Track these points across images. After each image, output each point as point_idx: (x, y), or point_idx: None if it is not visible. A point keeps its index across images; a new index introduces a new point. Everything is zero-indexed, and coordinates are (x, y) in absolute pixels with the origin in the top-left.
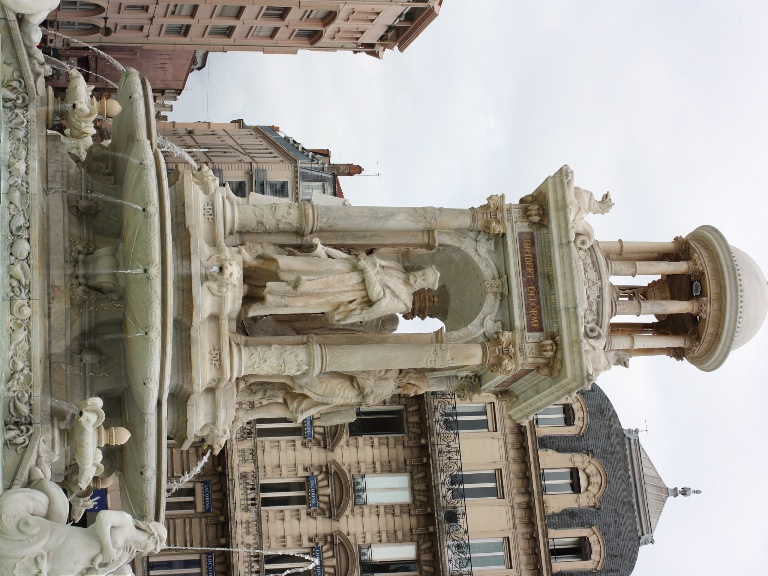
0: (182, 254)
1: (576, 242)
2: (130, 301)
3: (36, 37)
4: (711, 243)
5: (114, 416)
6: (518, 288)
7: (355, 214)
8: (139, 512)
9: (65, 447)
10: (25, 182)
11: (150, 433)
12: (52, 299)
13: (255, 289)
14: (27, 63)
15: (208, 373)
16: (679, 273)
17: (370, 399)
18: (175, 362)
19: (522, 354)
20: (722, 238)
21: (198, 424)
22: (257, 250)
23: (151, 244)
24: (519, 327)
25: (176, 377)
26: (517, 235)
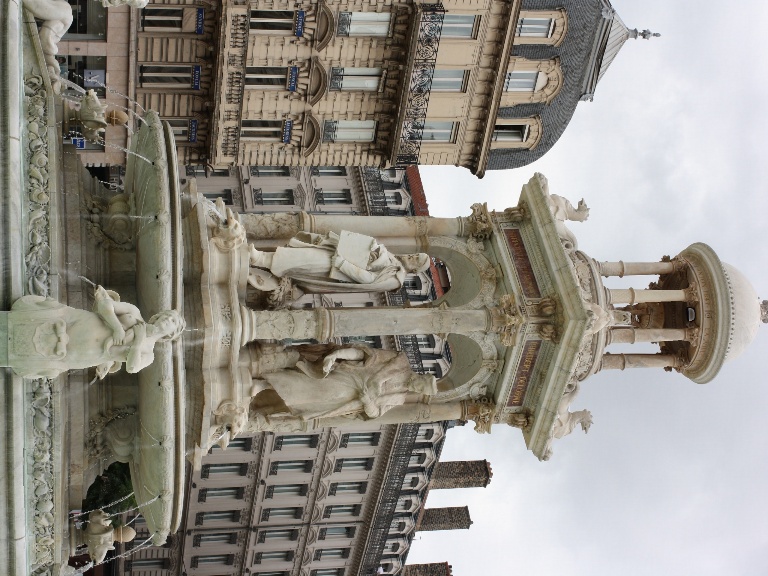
0: (195, 408)
1: None
2: None
3: None
4: (718, 315)
5: None
6: (510, 378)
7: (371, 331)
8: None
9: None
10: (49, 464)
11: None
12: (72, 472)
13: None
14: None
15: (209, 446)
16: None
17: None
18: None
19: (496, 420)
20: (728, 321)
21: None
22: (269, 361)
23: (164, 520)
24: (500, 402)
25: None
26: (525, 343)
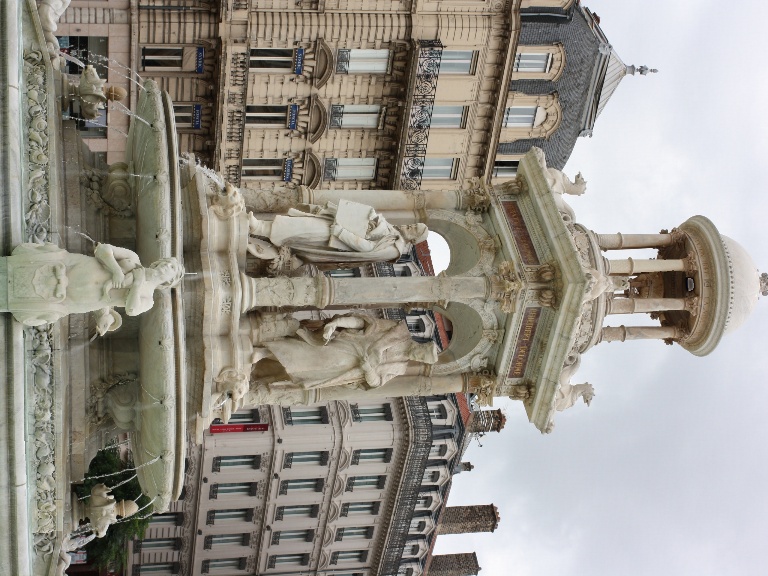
0: (196, 374)
1: None
2: None
3: None
4: (717, 284)
5: None
6: (511, 348)
7: (371, 298)
8: None
9: None
10: (50, 424)
11: None
12: (73, 440)
13: None
14: None
15: (211, 419)
16: None
17: None
18: None
19: (498, 392)
20: (728, 288)
21: None
22: (270, 329)
23: (165, 482)
24: (502, 374)
25: None
26: (525, 310)
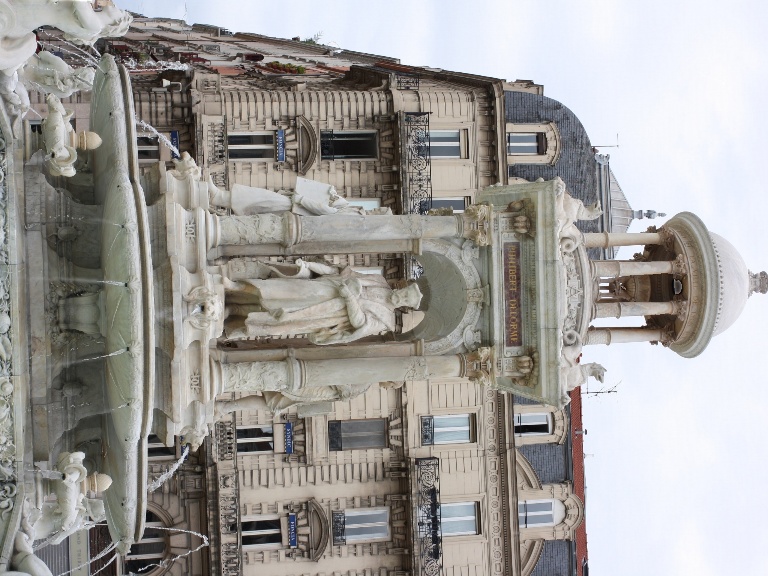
0: (164, 289)
1: (561, 246)
2: (112, 360)
3: (12, 86)
4: (697, 241)
5: (95, 426)
6: (500, 301)
7: (340, 227)
8: (120, 531)
9: None
10: (4, 251)
11: (131, 469)
12: (33, 351)
13: (236, 309)
14: (3, 112)
15: (188, 398)
16: None
17: (347, 398)
18: (156, 388)
19: (499, 369)
20: (708, 238)
21: (177, 430)
22: (239, 268)
23: (133, 322)
24: (498, 341)
25: (156, 403)
26: (502, 246)
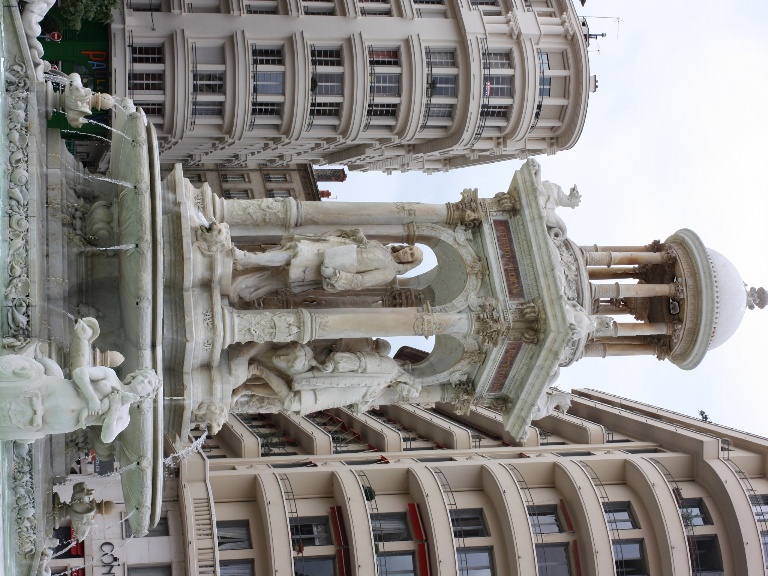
0: None
1: None
2: None
3: None
4: None
5: None
6: None
7: None
8: None
9: (57, 94)
10: None
11: None
12: None
13: None
14: None
15: None
16: (628, 271)
17: None
18: None
19: None
20: None
21: None
22: None
23: None
24: None
25: None
26: None
